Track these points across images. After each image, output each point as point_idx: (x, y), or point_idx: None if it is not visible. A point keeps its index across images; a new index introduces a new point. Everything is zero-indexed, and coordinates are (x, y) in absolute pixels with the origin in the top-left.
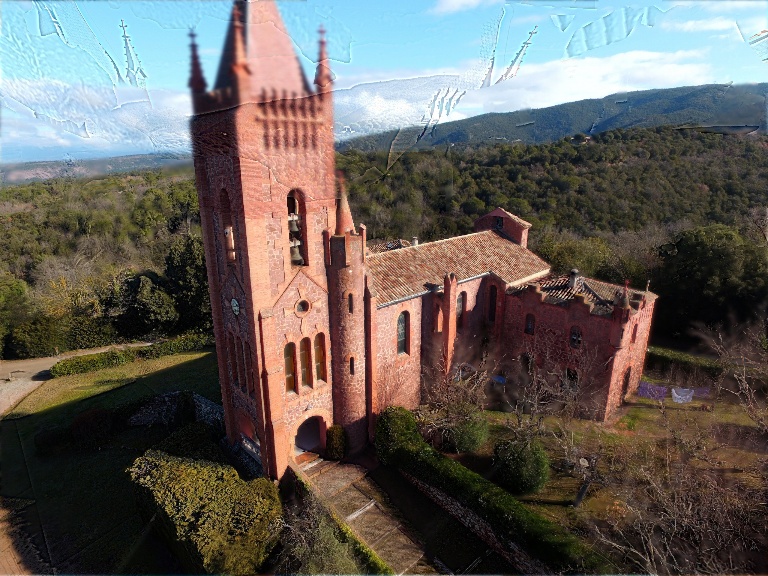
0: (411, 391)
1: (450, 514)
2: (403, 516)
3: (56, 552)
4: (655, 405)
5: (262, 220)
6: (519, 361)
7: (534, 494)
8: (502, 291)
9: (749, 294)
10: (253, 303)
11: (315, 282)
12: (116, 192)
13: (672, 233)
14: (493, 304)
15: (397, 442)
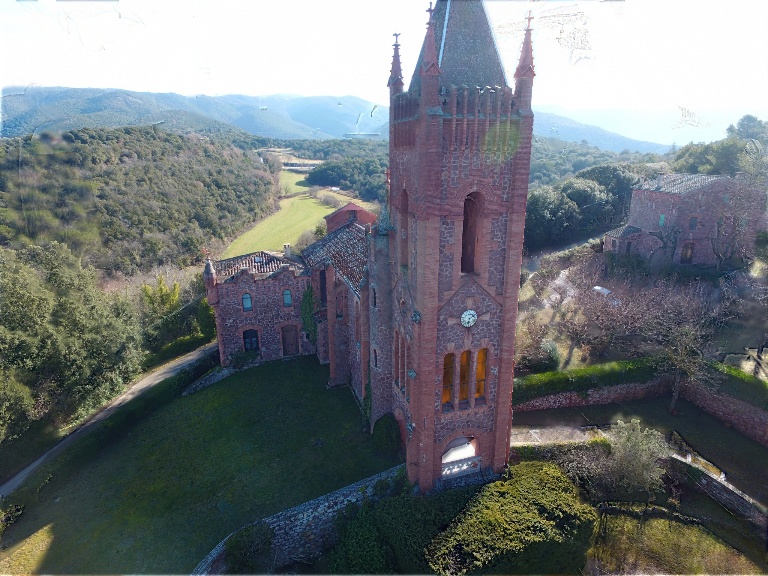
0: None
1: (546, 409)
2: (545, 426)
3: None
4: None
5: None
6: None
7: None
8: None
9: None
10: None
11: None
12: None
13: (373, 212)
14: None
15: None
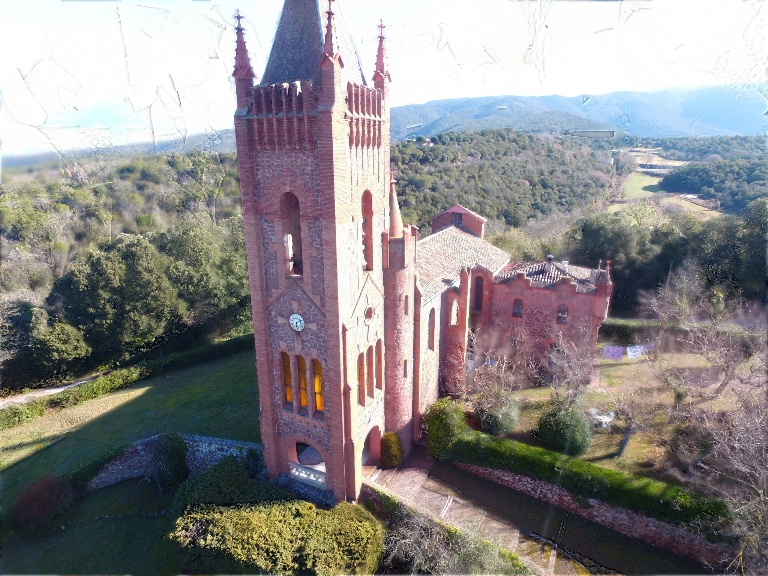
0: (433, 386)
1: (518, 491)
2: (482, 504)
3: None
4: (616, 363)
5: (346, 224)
6: (506, 343)
7: (584, 454)
8: (489, 281)
9: (644, 266)
10: (339, 315)
11: (377, 287)
12: None
13: (569, 221)
14: (478, 294)
15: (457, 435)
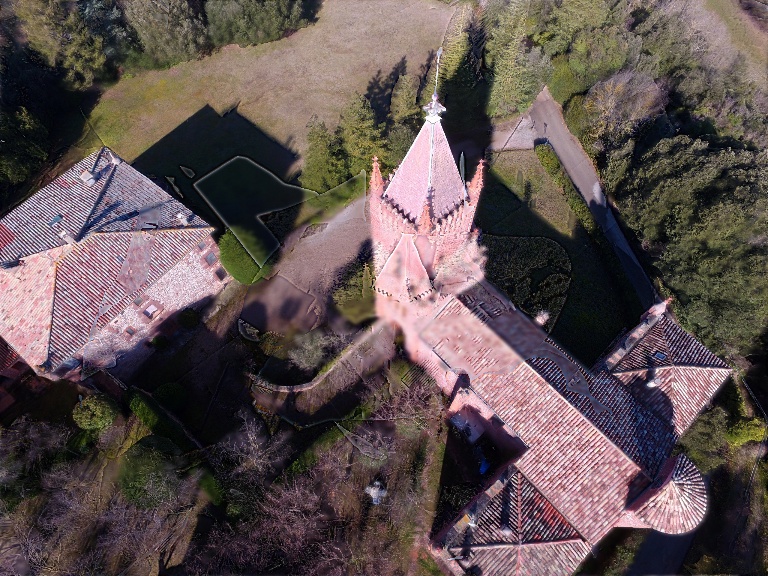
0: None
1: None
2: None
3: None
4: None
5: None
6: None
7: None
8: None
9: None
10: None
11: None
12: None
13: None
14: None
15: None
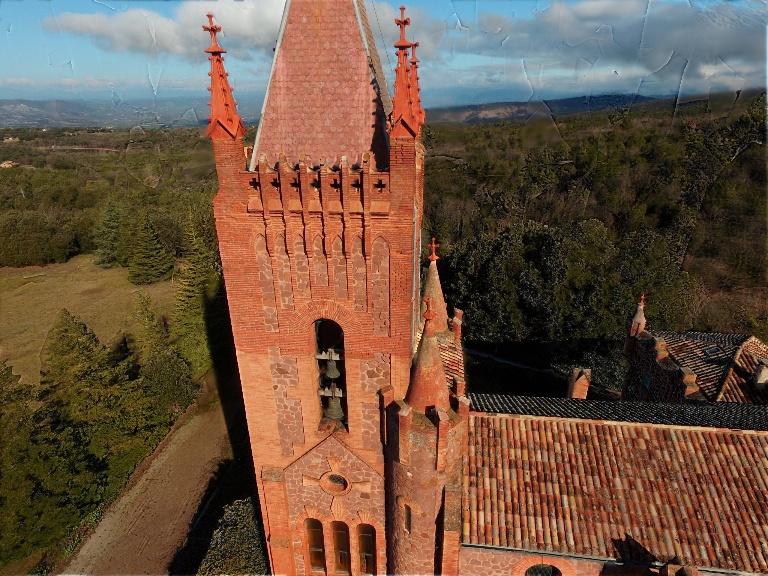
0: None
1: None
2: None
3: (200, 523)
4: None
5: (264, 356)
6: None
7: None
8: None
9: None
10: None
11: (360, 457)
12: (450, 169)
13: None
14: None
15: None
